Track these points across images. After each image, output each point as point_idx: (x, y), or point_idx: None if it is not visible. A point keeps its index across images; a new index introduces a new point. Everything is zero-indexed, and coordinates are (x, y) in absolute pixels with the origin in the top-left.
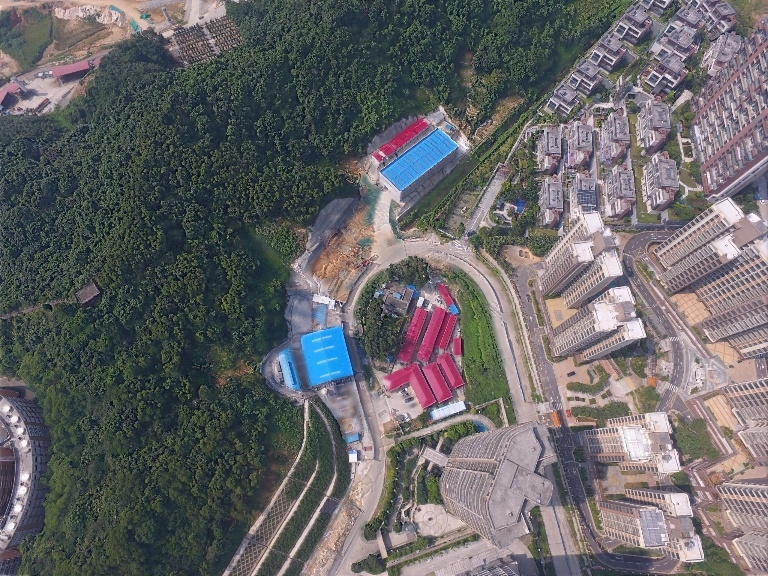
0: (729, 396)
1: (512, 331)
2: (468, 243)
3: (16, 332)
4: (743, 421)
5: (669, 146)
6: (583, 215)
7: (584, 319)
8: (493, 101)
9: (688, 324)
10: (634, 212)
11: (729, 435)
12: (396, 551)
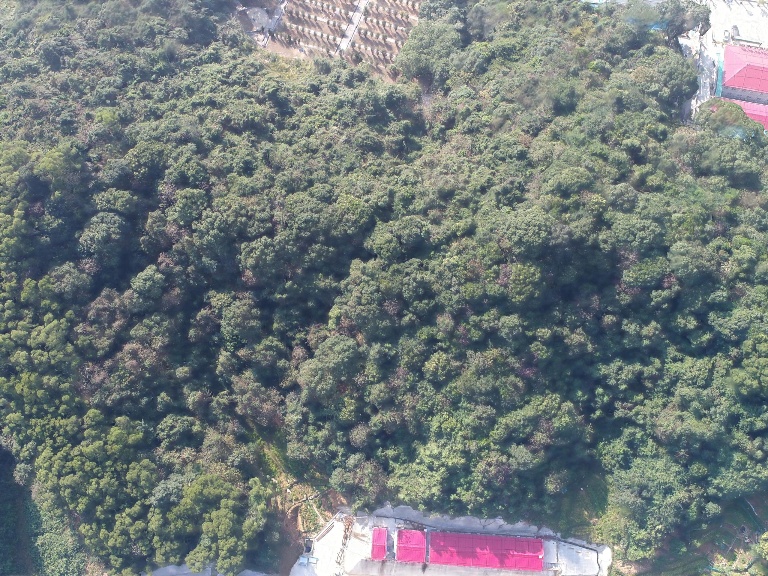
0: None
1: None
2: None
3: None
4: None
5: None
6: None
7: None
8: None
9: None
10: None
11: None
12: None
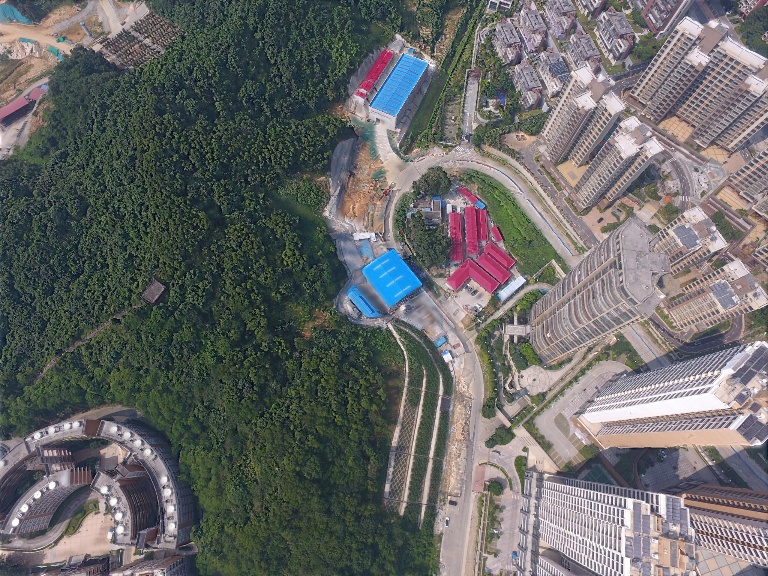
0: (734, 183)
1: (537, 204)
2: (469, 146)
3: (88, 359)
4: (752, 198)
5: (610, 4)
6: (574, 72)
7: (607, 157)
8: (440, 17)
9: (680, 142)
10: (602, 68)
11: (745, 214)
12: (516, 418)
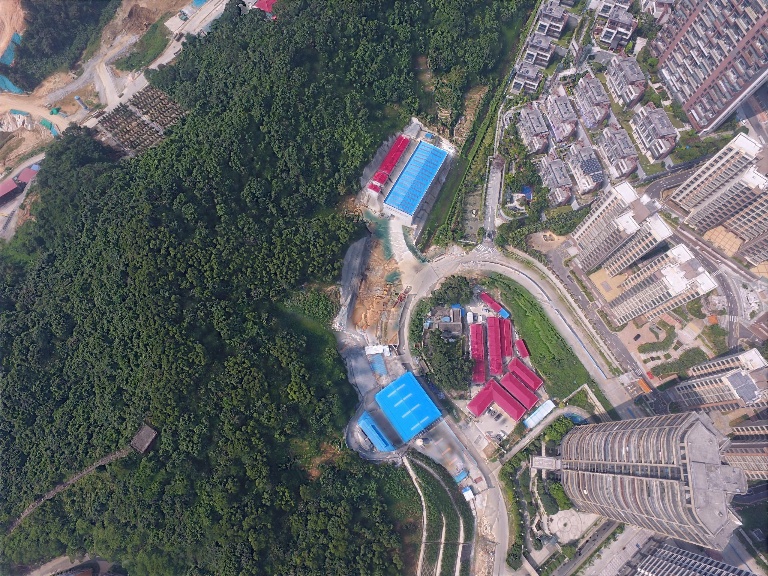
0: None
1: (567, 315)
2: (491, 244)
3: (70, 507)
4: None
5: (648, 96)
6: (614, 188)
7: (651, 287)
8: (460, 97)
9: (727, 256)
10: (639, 167)
11: None
12: (545, 568)
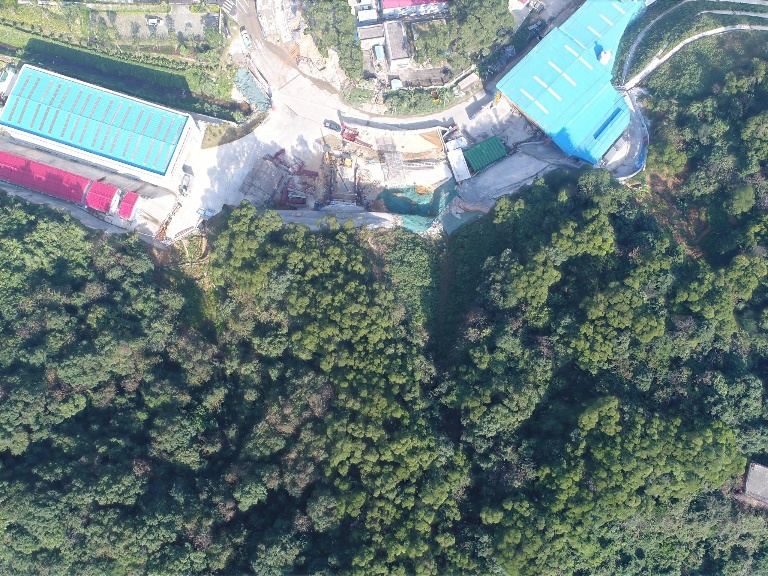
0: None
1: None
2: None
3: None
4: None
5: None
6: None
7: None
8: None
9: None
10: None
11: None
12: None
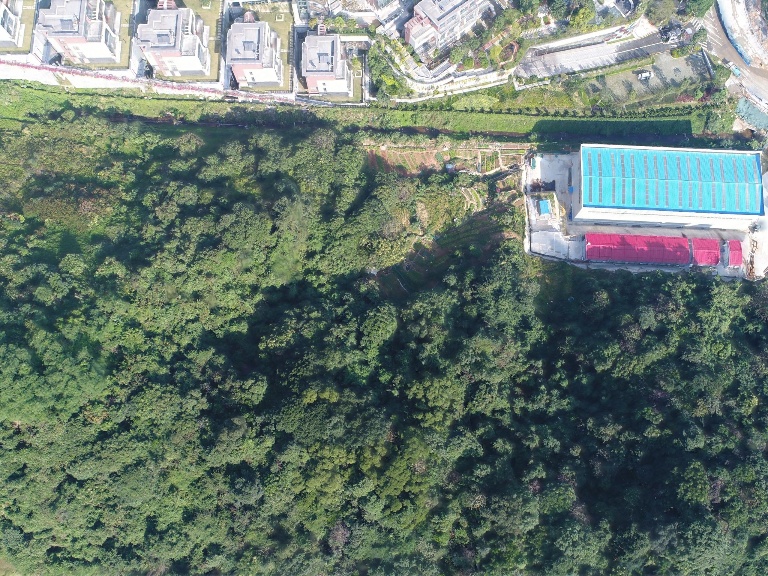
0: None
1: None
2: None
3: None
4: None
5: None
6: None
7: None
8: None
9: None
10: None
11: None
12: None
